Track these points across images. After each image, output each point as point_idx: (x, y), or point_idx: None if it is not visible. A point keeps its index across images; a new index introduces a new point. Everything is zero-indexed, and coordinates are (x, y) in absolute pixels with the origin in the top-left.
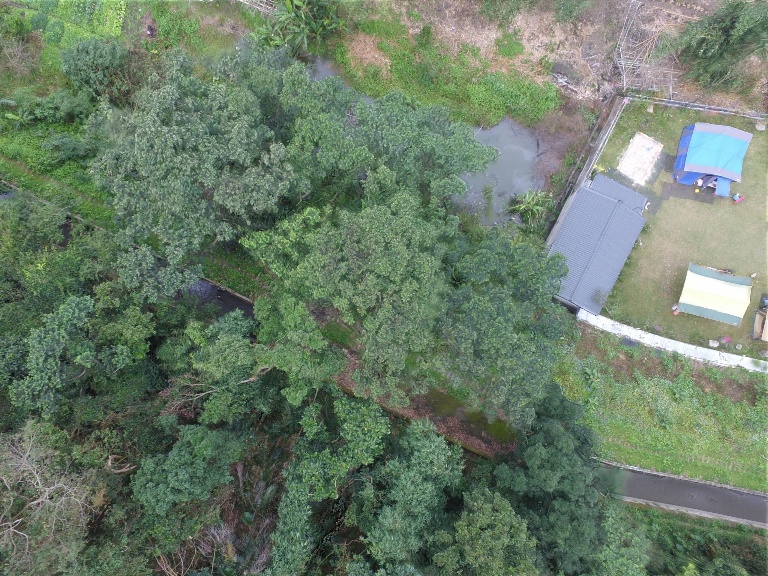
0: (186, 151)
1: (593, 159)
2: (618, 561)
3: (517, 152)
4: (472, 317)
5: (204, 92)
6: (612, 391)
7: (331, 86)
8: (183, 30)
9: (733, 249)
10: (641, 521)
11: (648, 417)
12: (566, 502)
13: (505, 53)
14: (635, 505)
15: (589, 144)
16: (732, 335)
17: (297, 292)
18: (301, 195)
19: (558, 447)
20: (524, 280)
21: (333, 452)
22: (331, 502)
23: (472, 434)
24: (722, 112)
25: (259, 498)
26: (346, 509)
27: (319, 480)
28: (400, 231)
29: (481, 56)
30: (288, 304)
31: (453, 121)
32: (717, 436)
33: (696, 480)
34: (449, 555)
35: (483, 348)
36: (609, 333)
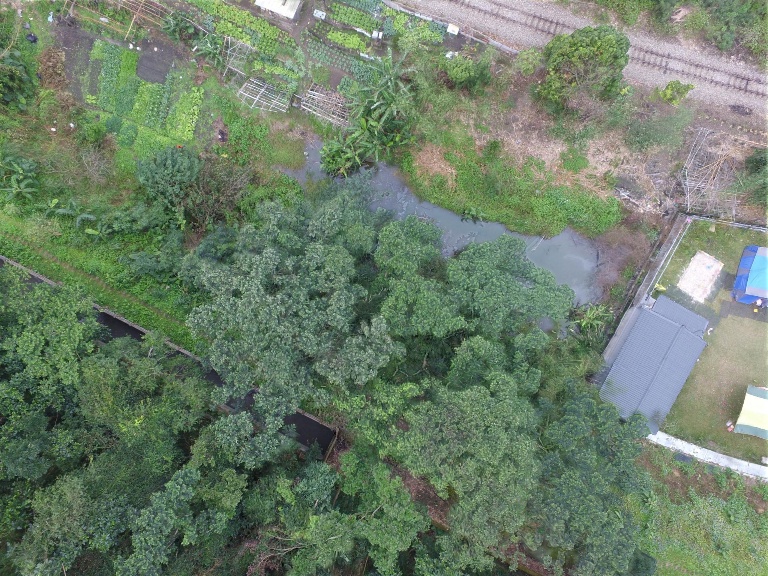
0: (287, 318)
1: (654, 276)
2: None
3: (577, 262)
4: (563, 493)
5: (301, 250)
6: (668, 513)
7: (418, 234)
8: (253, 135)
9: None
10: None
11: (704, 541)
12: None
13: (570, 167)
14: None
15: (649, 259)
16: None
17: (395, 467)
18: (396, 362)
19: None
20: None
21: None
22: None
23: (532, 556)
24: None
25: None
26: None
27: None
28: (501, 416)
29: (546, 169)
30: (384, 477)
31: (515, 230)
32: None
33: None
34: None
35: (573, 525)
36: (663, 448)
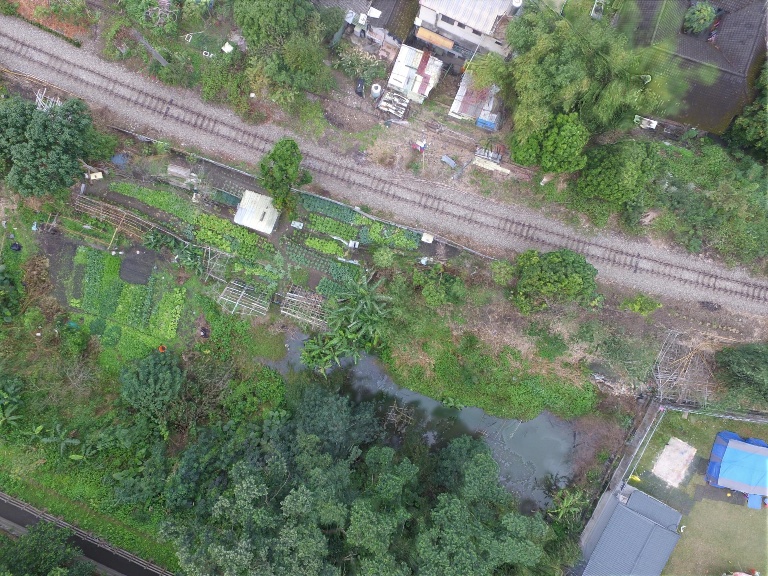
0: None
1: (629, 463)
2: None
3: (554, 443)
4: None
5: (276, 533)
6: None
7: (391, 492)
8: (235, 330)
9: (763, 548)
10: None
11: None
12: None
13: (545, 356)
14: None
15: (625, 443)
16: None
17: None
18: None
19: None
20: None
21: None
22: None
23: None
24: (754, 420)
25: None
26: None
27: None
28: None
29: (522, 356)
30: None
31: (493, 415)
32: None
33: None
34: None
35: None
36: None
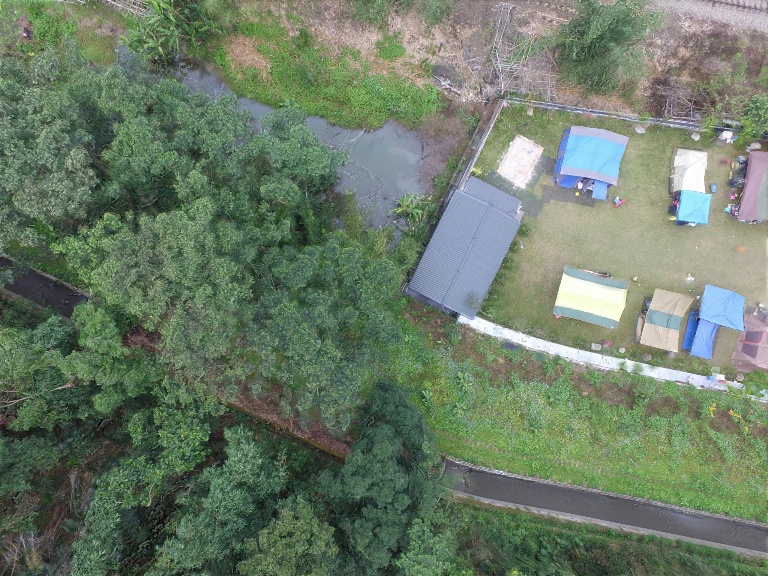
0: None
1: (473, 162)
2: (414, 569)
3: (401, 155)
4: (277, 323)
5: (21, 96)
6: (484, 395)
7: (165, 90)
8: (60, 32)
9: (615, 252)
10: (508, 526)
11: (519, 421)
12: (374, 509)
13: (386, 56)
14: (504, 510)
15: (471, 147)
16: (615, 338)
17: (95, 298)
18: (111, 200)
19: (374, 454)
20: (351, 285)
21: (149, 459)
22: (147, 509)
23: (337, 439)
24: (602, 115)
25: (85, 505)
26: (166, 516)
27: (129, 487)
28: (193, 237)
29: (362, 59)
30: (88, 310)
31: (335, 124)
32: (588, 440)
33: (563, 484)
34: (252, 563)
35: (287, 354)
36: (490, 337)
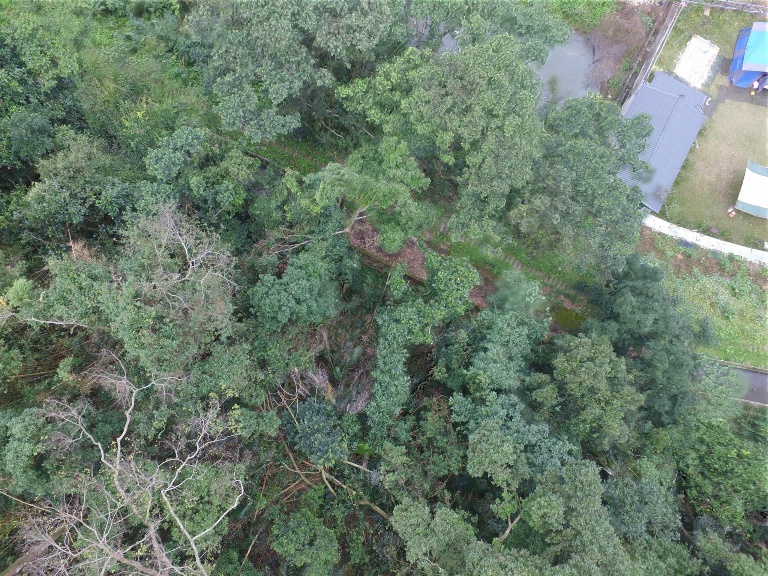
0: None
1: (651, 62)
2: (717, 389)
3: (573, 59)
4: (569, 159)
5: None
6: (674, 285)
7: None
8: None
9: None
10: (705, 408)
11: (710, 309)
12: (660, 342)
13: None
14: None
15: (645, 49)
16: None
17: (399, 130)
18: (397, 44)
19: (648, 294)
20: (609, 140)
21: (426, 302)
22: (425, 351)
23: None
24: None
25: (348, 356)
26: (437, 361)
27: (416, 324)
28: (503, 65)
29: None
30: (389, 144)
31: None
32: None
33: (759, 368)
34: (548, 391)
35: (580, 188)
36: (666, 235)
